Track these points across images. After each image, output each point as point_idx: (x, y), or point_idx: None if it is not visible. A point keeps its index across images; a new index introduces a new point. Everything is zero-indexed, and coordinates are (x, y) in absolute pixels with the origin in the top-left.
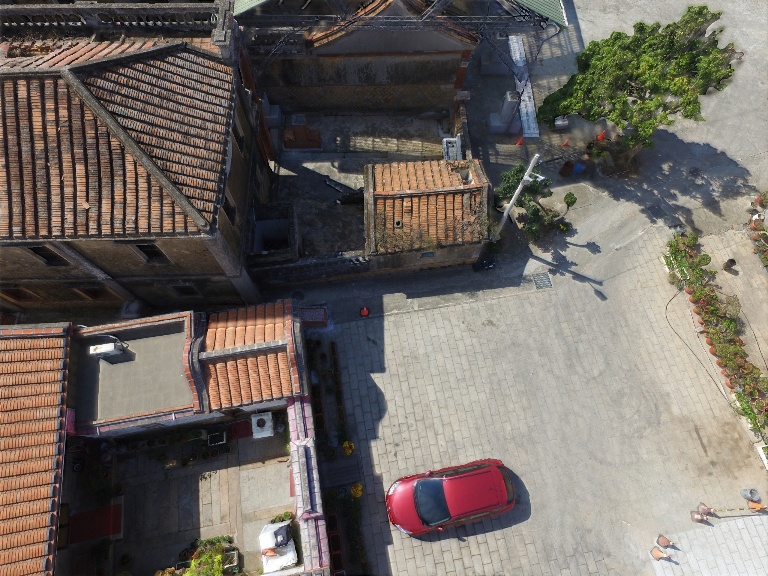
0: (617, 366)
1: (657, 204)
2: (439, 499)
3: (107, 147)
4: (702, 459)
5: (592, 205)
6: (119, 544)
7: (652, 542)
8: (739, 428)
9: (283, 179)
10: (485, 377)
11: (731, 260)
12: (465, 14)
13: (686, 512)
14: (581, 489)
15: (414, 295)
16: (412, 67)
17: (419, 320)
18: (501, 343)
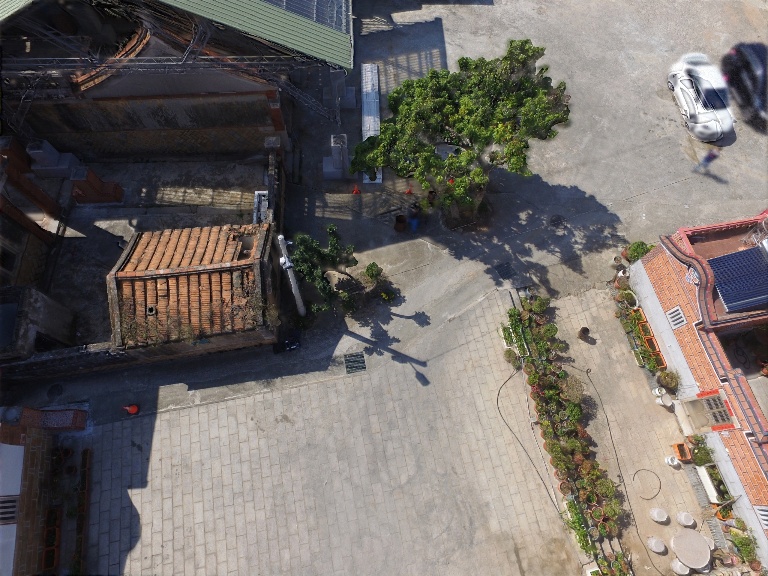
0: (430, 470)
1: (507, 261)
2: None
3: None
4: None
5: (428, 266)
6: None
7: None
8: (568, 546)
9: (68, 242)
10: (268, 489)
11: (584, 328)
12: (235, 54)
13: None
14: None
15: (197, 385)
16: (215, 109)
17: (199, 417)
18: (294, 444)
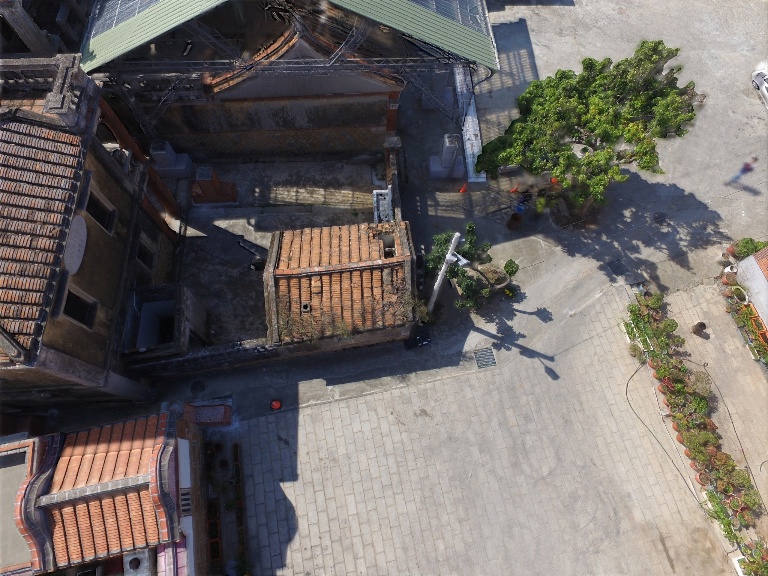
0: (570, 461)
1: (617, 258)
2: None
3: None
4: None
5: (543, 263)
6: None
7: None
8: (711, 534)
9: (190, 241)
10: (415, 482)
11: (700, 323)
12: (381, 56)
13: None
14: None
15: (335, 381)
16: (334, 110)
17: (340, 412)
18: (435, 438)
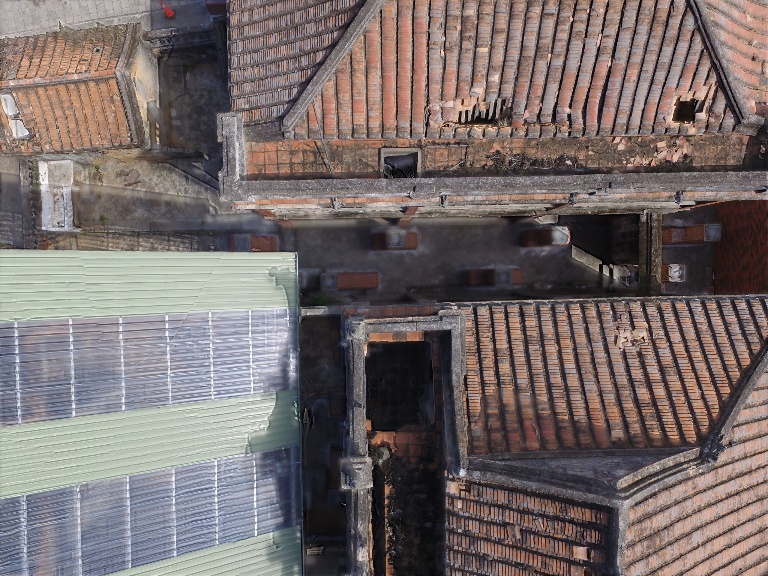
0: None
1: None
2: None
3: None
4: None
5: None
6: None
7: None
8: None
9: None
10: None
11: None
12: None
13: None
14: None
15: None
16: None
17: (113, 6)
18: None
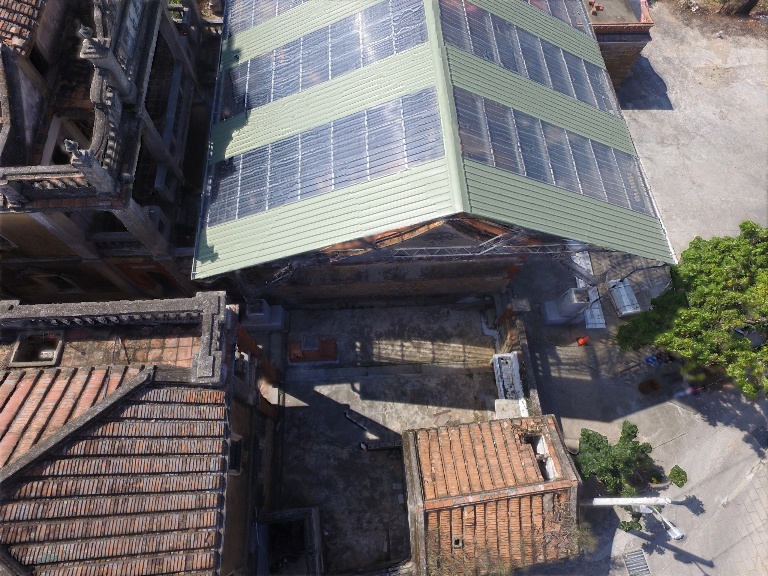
0: None
1: (761, 425)
2: None
3: None
4: None
5: (684, 436)
6: None
7: None
8: None
9: (290, 413)
10: None
11: None
12: (537, 243)
13: None
14: None
15: None
16: (453, 267)
17: None
18: None
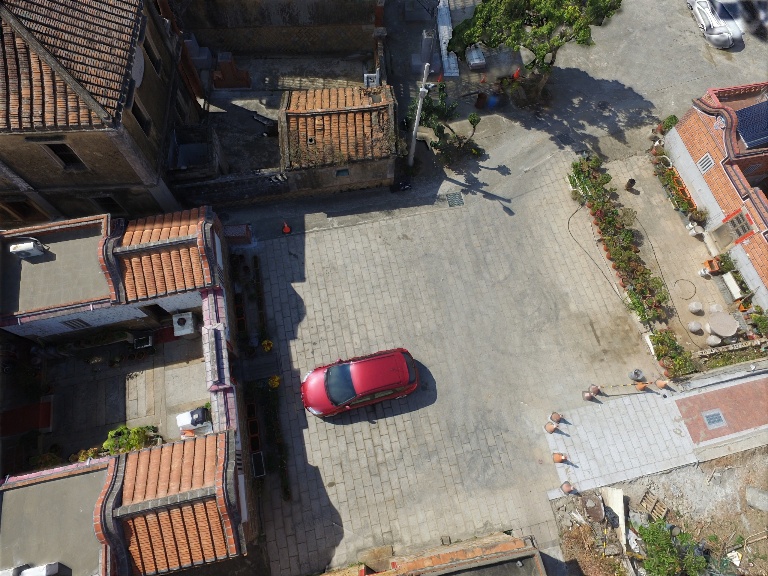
0: (521, 271)
1: (566, 133)
2: (346, 381)
3: (12, 46)
4: (595, 348)
5: (504, 133)
6: (48, 437)
7: (546, 418)
8: (630, 321)
9: (212, 115)
10: (398, 283)
11: (631, 180)
12: None
13: (578, 392)
14: (483, 376)
15: (334, 214)
16: (332, 6)
17: (338, 236)
18: (414, 254)
